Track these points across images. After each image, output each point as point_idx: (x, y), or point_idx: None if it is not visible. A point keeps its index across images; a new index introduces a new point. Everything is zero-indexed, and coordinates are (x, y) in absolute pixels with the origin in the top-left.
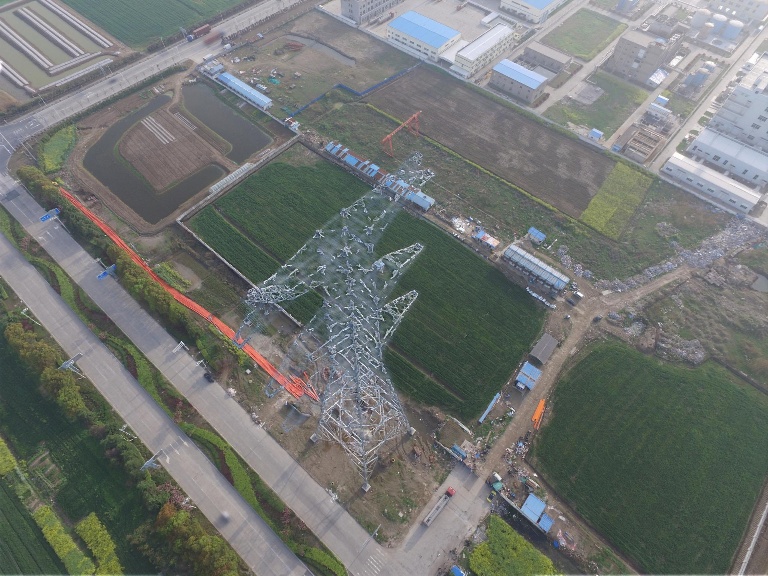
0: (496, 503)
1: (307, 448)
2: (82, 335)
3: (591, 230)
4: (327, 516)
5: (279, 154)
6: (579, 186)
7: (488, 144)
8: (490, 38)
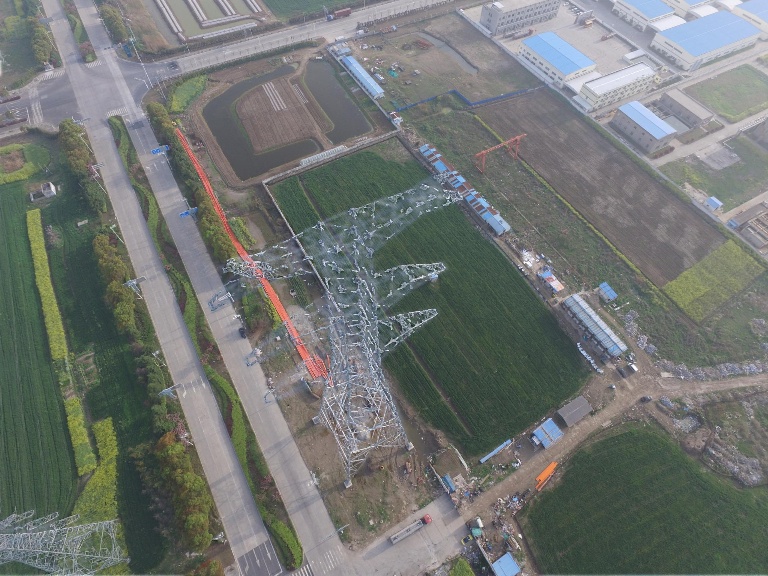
0: (469, 548)
1: (307, 427)
2: (152, 261)
3: (672, 304)
4: (303, 497)
5: (374, 144)
6: (674, 253)
7: (587, 184)
8: (626, 76)
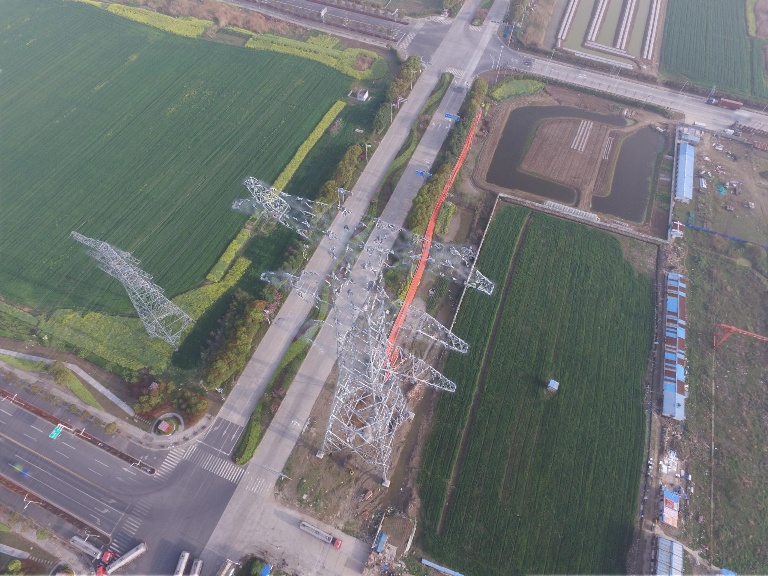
0: None
1: None
2: (370, 189)
3: None
4: (288, 428)
5: (629, 236)
6: None
7: None
8: None
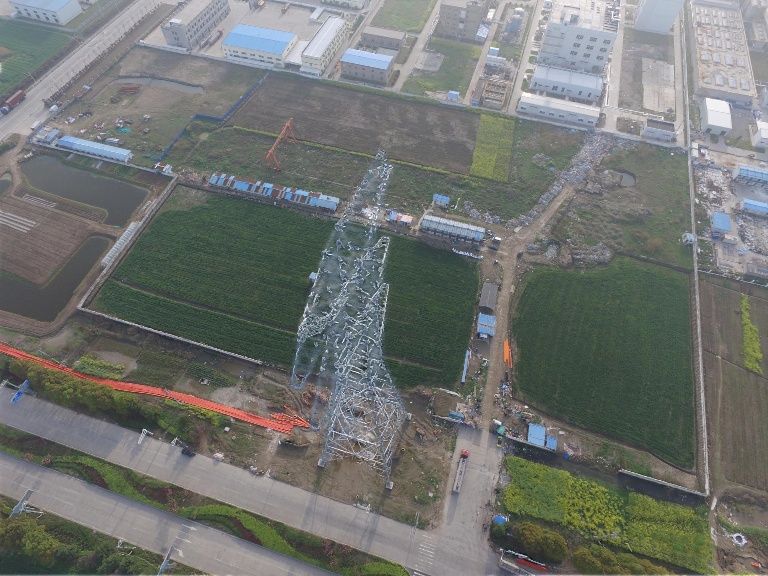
0: (505, 445)
1: (319, 476)
2: (20, 470)
3: (484, 180)
4: (365, 529)
5: (163, 203)
6: (458, 145)
7: (365, 131)
8: (327, 32)
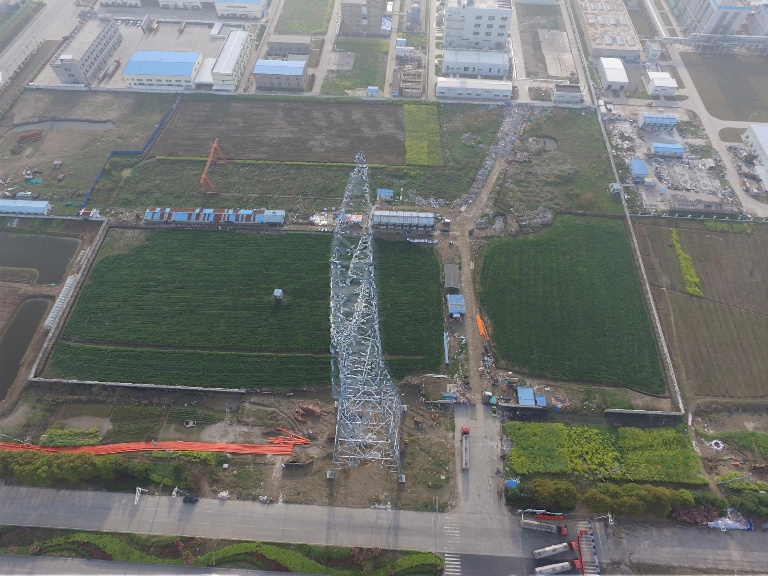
0: (500, 413)
1: (330, 488)
2: (5, 567)
3: (421, 167)
4: (389, 527)
5: (98, 250)
6: (389, 138)
7: (294, 140)
8: (232, 47)
